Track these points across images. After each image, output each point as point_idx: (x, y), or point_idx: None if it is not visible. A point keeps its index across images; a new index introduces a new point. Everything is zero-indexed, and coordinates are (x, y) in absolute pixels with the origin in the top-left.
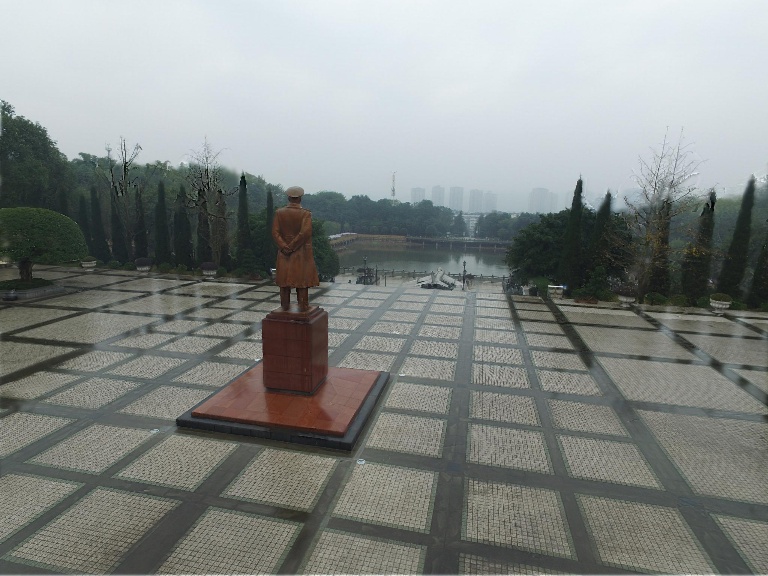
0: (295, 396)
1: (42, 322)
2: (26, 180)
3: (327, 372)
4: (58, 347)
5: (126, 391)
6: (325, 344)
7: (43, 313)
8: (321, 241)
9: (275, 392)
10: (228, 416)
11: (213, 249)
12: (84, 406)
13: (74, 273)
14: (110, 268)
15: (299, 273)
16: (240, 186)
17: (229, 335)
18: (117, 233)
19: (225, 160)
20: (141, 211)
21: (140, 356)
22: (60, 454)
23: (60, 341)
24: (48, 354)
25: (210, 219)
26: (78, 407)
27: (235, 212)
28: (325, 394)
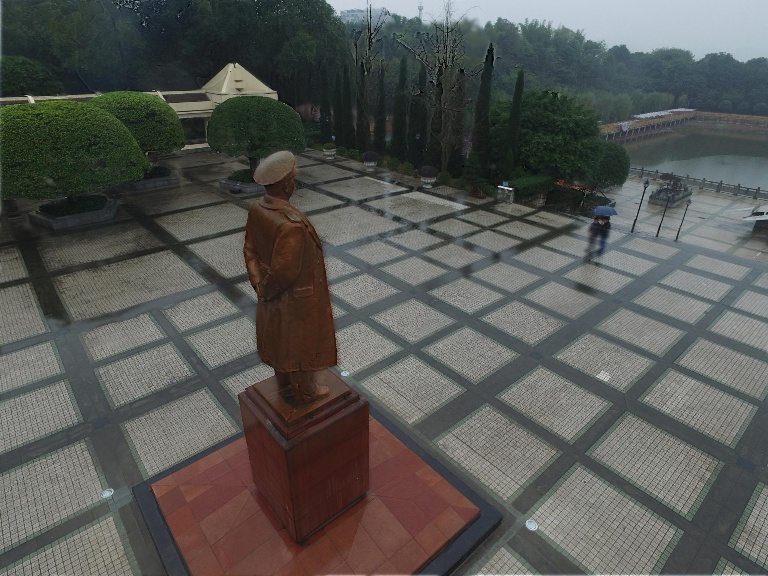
0: (277, 531)
1: (224, 231)
2: (295, 57)
3: (367, 488)
4: (197, 276)
5: (167, 383)
6: (358, 453)
7: (238, 217)
8: (587, 147)
9: (264, 500)
10: (170, 526)
11: (442, 148)
12: (112, 396)
13: (315, 161)
14: (349, 157)
15: (278, 344)
16: (485, 63)
17: (358, 304)
18: (360, 118)
19: (470, 25)
20: (381, 94)
21: (240, 317)
22: (3, 490)
23: (208, 266)
24: (180, 285)
25: (442, 109)
26: (107, 396)
27: (473, 100)
28: (325, 551)
